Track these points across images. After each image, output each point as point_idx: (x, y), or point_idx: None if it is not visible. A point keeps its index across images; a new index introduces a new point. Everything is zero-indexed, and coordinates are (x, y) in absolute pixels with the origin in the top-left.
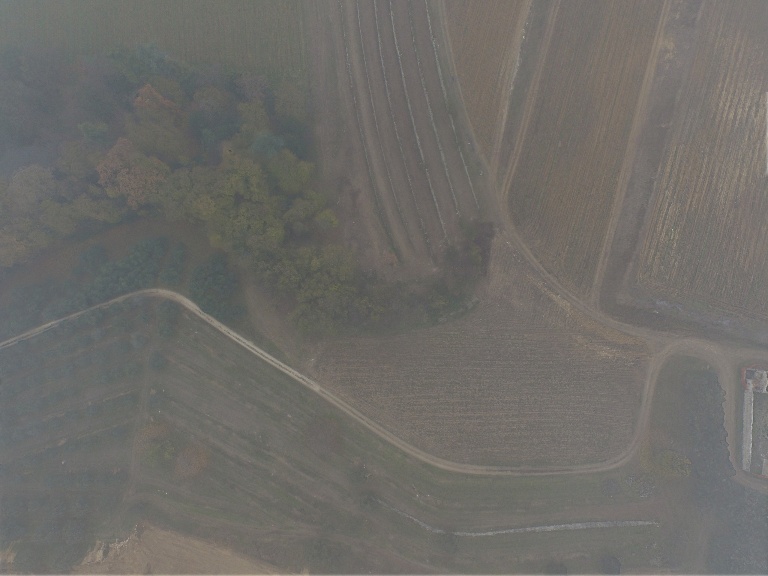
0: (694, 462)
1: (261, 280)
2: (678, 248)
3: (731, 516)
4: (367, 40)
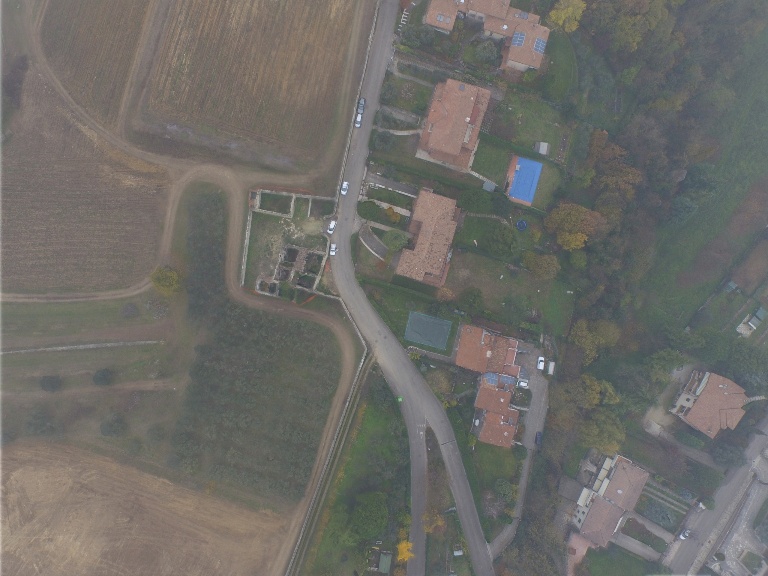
0: (186, 278)
1: None
2: (189, 73)
3: (211, 326)
4: None
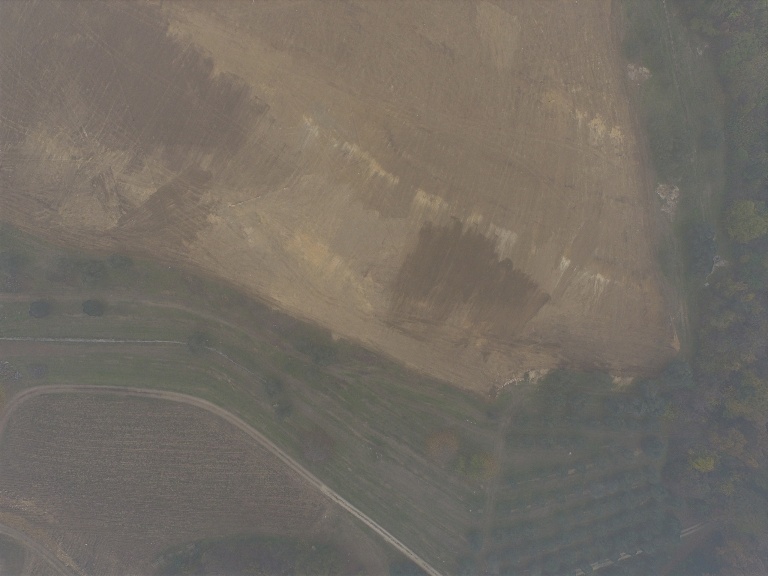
0: None
1: None
2: None
3: None
4: None
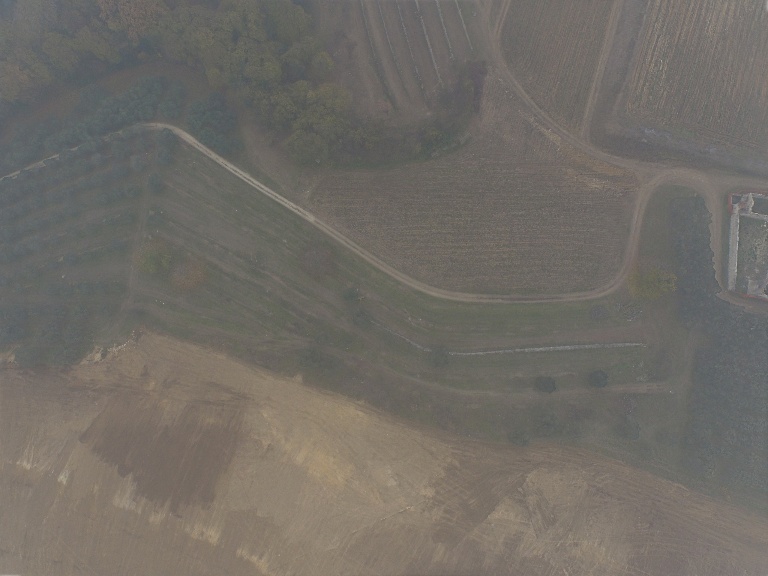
0: (680, 280)
1: (258, 113)
2: (667, 78)
3: (716, 328)
4: None
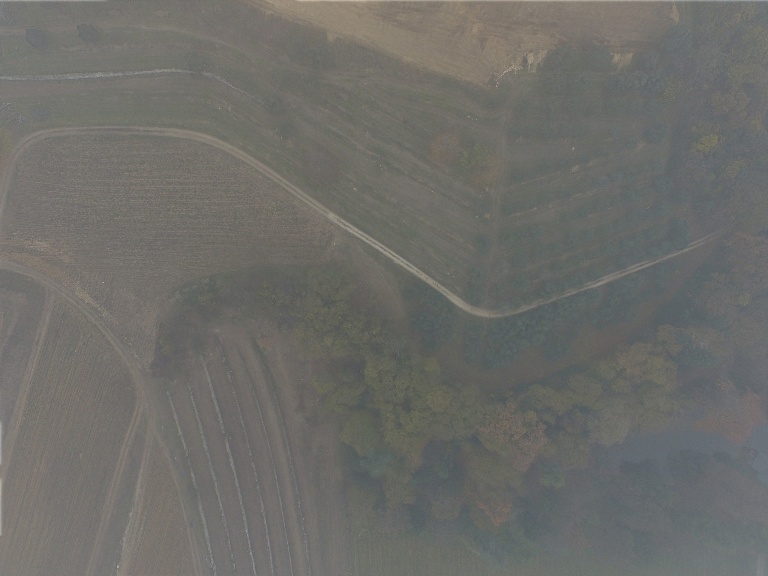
0: None
1: (384, 324)
2: None
3: None
4: (285, 567)
